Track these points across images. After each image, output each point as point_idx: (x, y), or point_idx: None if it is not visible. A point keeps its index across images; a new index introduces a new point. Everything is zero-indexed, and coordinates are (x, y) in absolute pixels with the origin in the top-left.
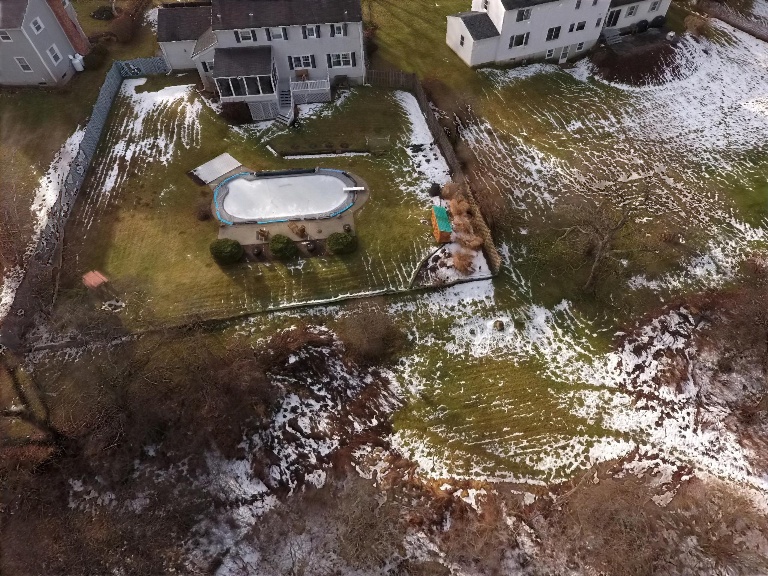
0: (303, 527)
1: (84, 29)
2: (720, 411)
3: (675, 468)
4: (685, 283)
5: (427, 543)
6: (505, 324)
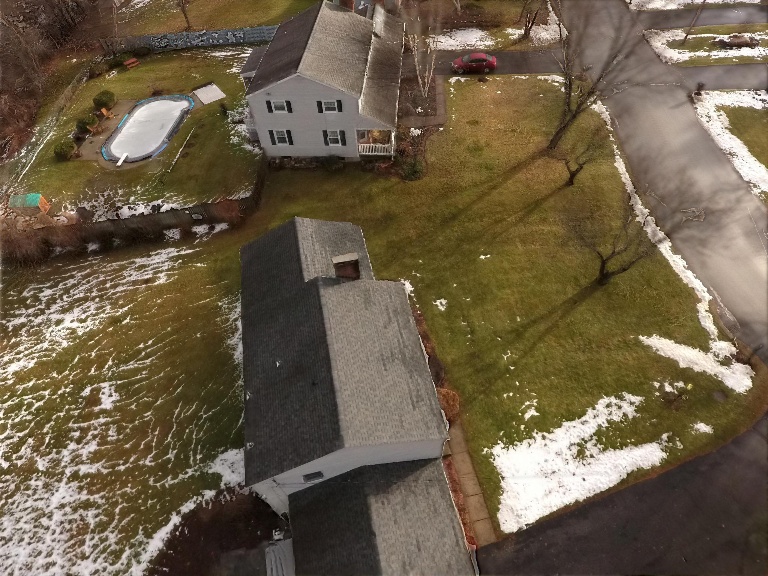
0: None
1: (437, 6)
2: None
3: None
4: None
5: None
6: None
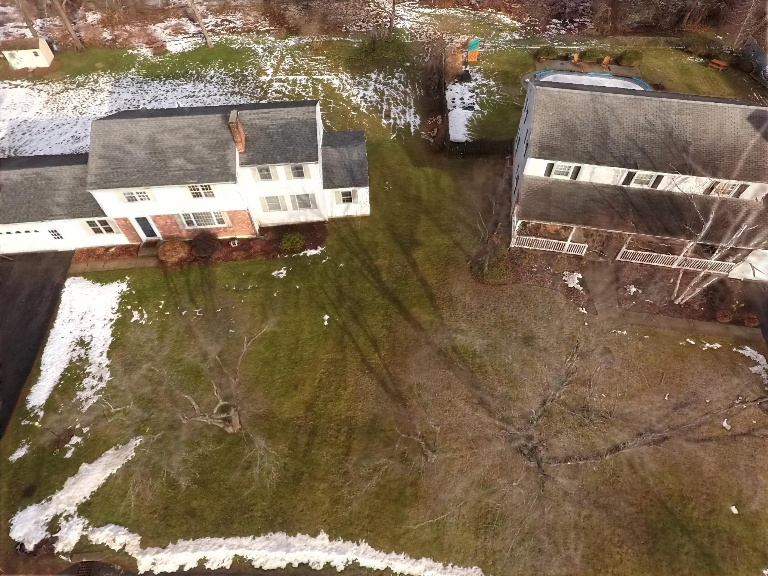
0: (562, 13)
1: None
2: (367, 8)
3: (402, 3)
4: (328, 38)
5: (512, 5)
6: (447, 39)
